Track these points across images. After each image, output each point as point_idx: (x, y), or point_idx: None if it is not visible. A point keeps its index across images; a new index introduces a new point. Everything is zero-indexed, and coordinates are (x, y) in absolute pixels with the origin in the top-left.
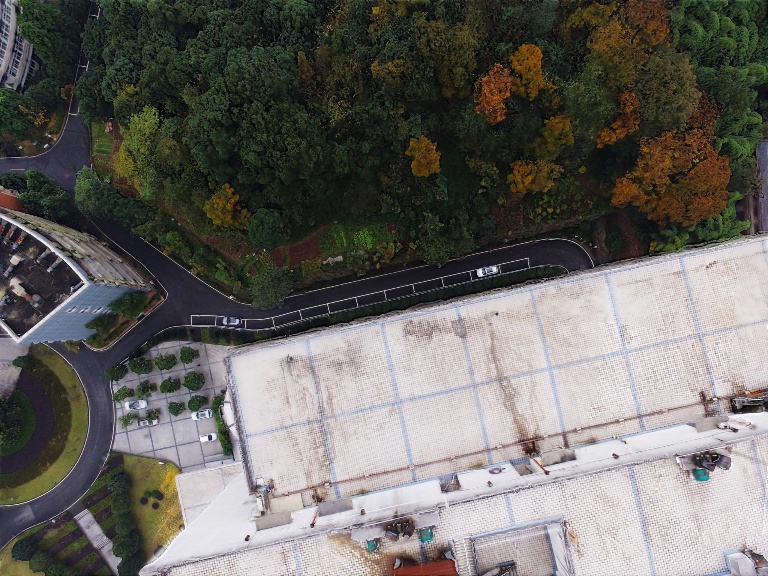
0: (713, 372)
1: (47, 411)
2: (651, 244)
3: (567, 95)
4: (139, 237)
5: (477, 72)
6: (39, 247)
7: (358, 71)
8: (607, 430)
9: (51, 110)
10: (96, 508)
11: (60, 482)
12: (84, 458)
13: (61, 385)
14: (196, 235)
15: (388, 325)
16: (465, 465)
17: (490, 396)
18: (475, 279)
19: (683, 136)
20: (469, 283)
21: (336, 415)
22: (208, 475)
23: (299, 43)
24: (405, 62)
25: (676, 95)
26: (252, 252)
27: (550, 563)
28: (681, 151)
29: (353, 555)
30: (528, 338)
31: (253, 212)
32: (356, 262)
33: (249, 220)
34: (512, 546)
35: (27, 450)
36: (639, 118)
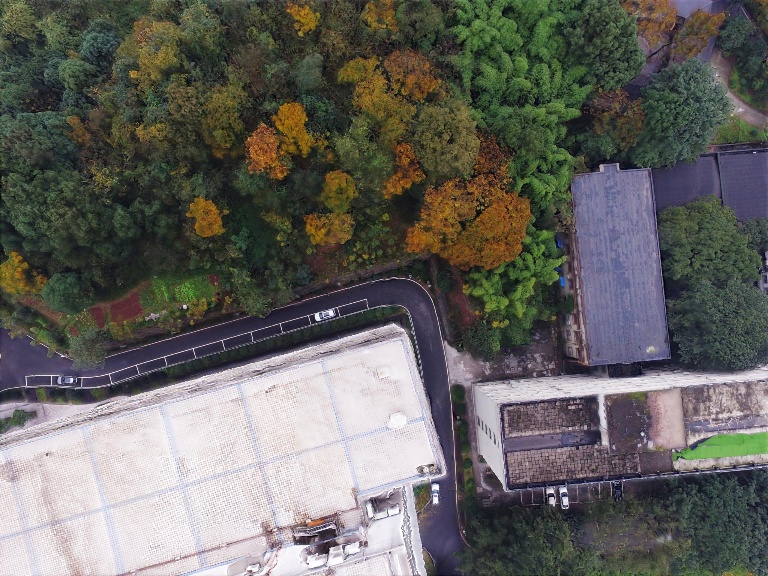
0: (274, 501)
1: None
2: (463, 287)
3: (338, 151)
4: None
5: (250, 130)
6: None
7: (126, 135)
8: (164, 570)
9: None
10: None
11: None
12: None
13: None
14: None
15: None
16: None
17: (41, 542)
18: (314, 323)
19: (464, 185)
20: (307, 328)
21: None
22: None
23: (80, 104)
24: (166, 126)
25: (452, 145)
26: None
27: None
28: (464, 200)
29: None
30: (81, 478)
31: None
32: (168, 320)
33: None
34: None
35: None
36: (419, 169)
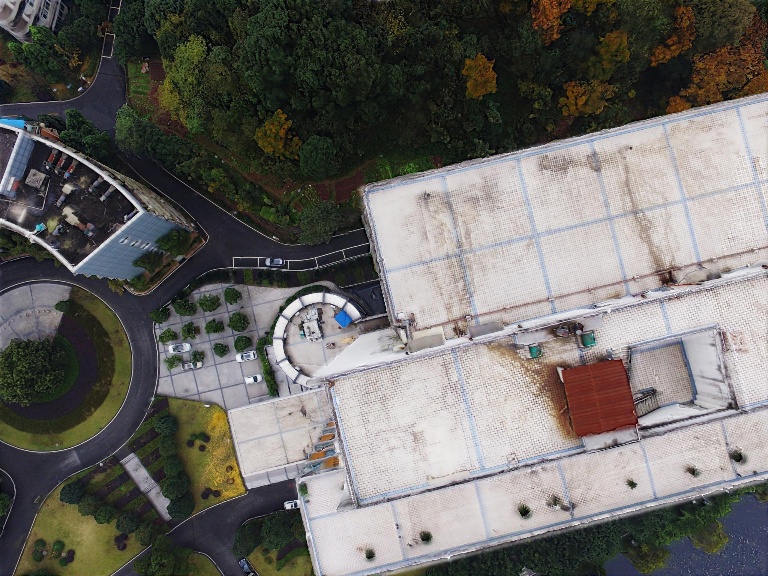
0: None
1: (90, 356)
2: None
3: (626, 8)
4: (178, 180)
5: None
6: (90, 176)
7: None
8: (741, 259)
9: (84, 52)
10: (142, 452)
11: (105, 427)
12: (128, 403)
13: (103, 330)
14: (240, 172)
15: (524, 160)
16: (603, 296)
17: (626, 228)
18: None
19: (738, 51)
20: None
21: (475, 250)
22: (260, 409)
23: None
24: None
25: (732, 9)
26: (297, 188)
27: (689, 389)
28: (736, 66)
29: (513, 366)
30: (662, 171)
31: (304, 141)
32: None
33: (301, 148)
34: (651, 373)
35: (71, 395)
36: (695, 33)
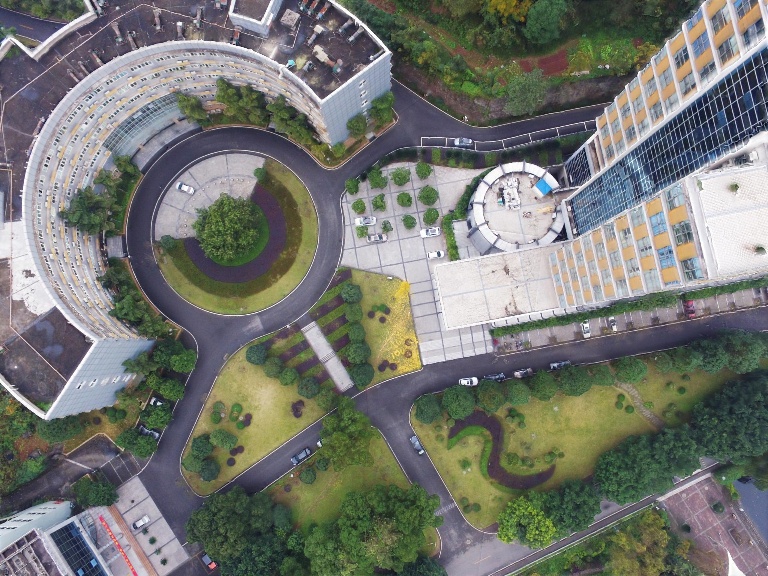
0: None
1: (280, 224)
2: None
3: None
4: None
5: None
6: (338, 20)
7: None
8: None
9: None
10: (324, 320)
11: (289, 294)
12: (313, 272)
13: (293, 200)
14: (446, 48)
15: None
16: None
17: None
18: None
19: None
20: None
21: None
22: (465, 266)
23: None
24: None
25: None
26: (500, 64)
27: None
28: None
29: None
30: None
31: None
32: (619, 61)
33: (531, 7)
34: None
35: (260, 261)
36: None
